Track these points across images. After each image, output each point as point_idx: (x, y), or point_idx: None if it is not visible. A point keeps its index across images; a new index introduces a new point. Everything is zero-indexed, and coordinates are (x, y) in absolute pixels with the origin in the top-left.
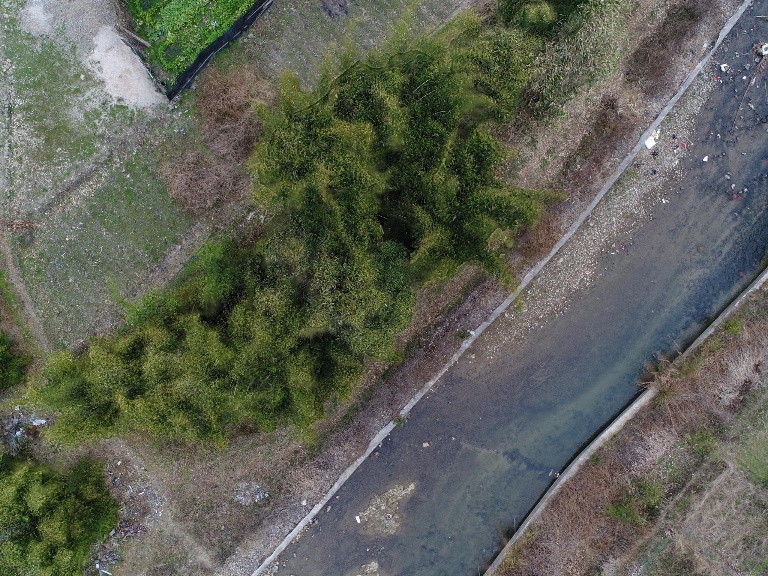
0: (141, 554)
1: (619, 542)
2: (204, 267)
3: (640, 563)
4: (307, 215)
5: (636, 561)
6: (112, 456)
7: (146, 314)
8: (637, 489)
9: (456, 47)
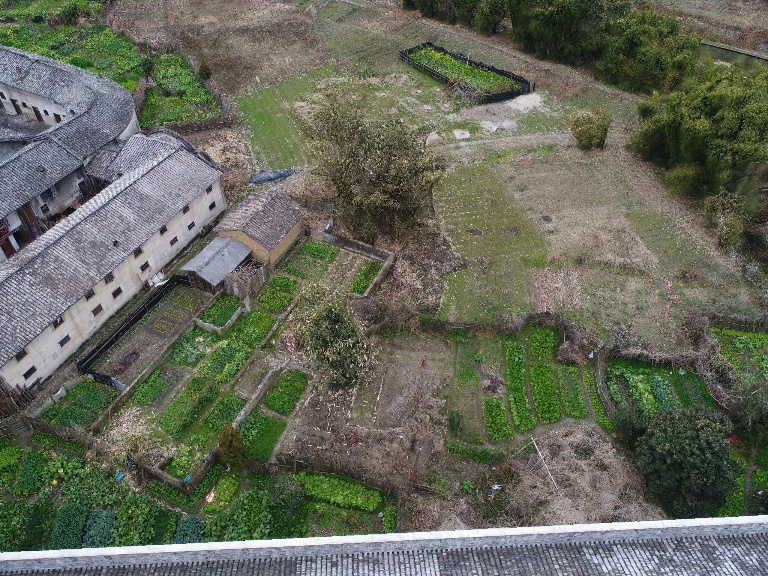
0: None
1: (659, 8)
2: (618, 46)
3: (664, 2)
4: (588, 4)
5: (664, 3)
6: None
7: (649, 63)
8: (636, 5)
9: (490, 15)
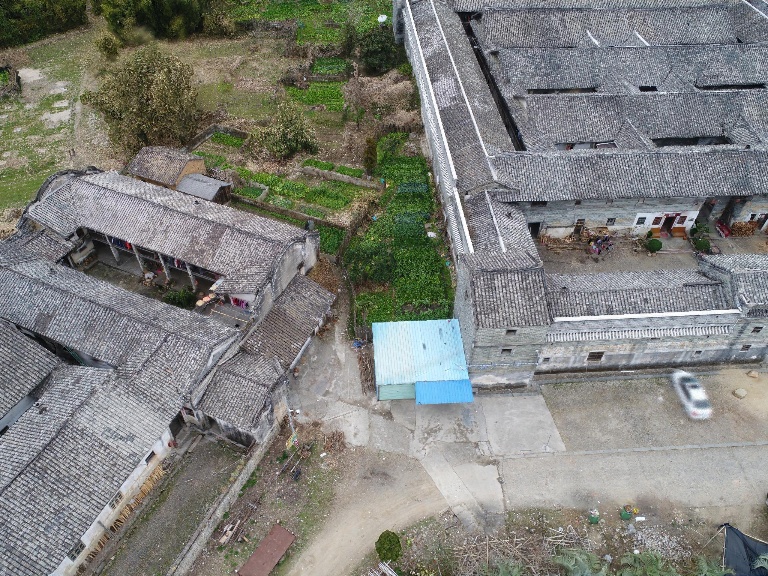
0: (90, 5)
1: None
2: None
3: None
4: None
5: None
6: (90, 17)
7: (36, 11)
8: None
9: None
